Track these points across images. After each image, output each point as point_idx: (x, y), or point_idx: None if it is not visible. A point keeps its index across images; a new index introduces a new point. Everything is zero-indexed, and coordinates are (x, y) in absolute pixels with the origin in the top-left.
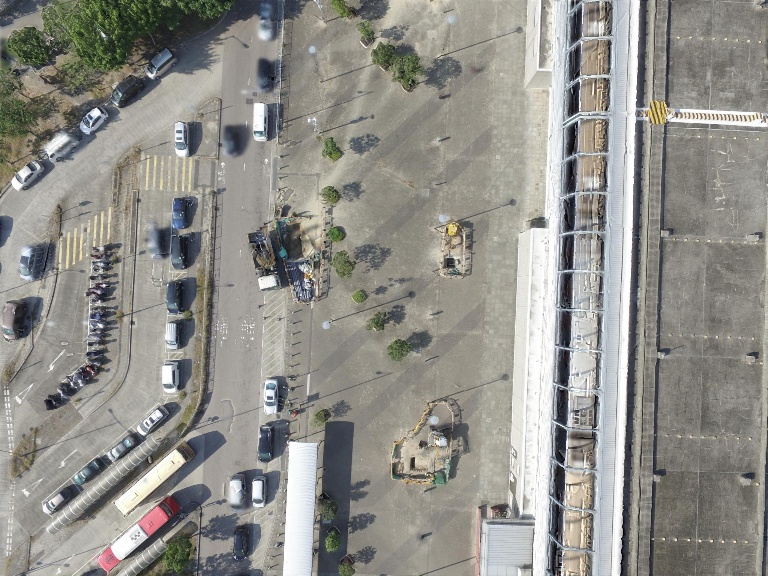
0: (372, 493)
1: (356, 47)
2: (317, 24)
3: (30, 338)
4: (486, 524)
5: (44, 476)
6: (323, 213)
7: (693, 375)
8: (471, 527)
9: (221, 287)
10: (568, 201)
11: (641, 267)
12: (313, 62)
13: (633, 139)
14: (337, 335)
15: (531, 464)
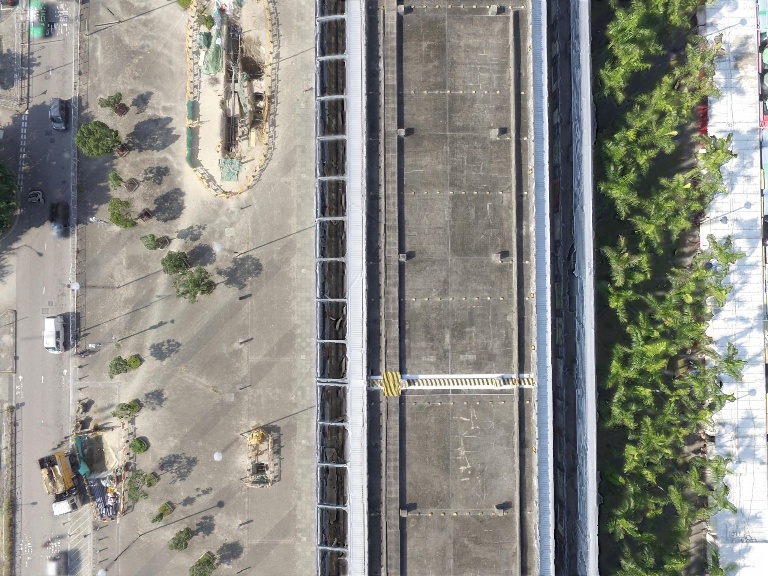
0: None
1: (152, 250)
2: (111, 228)
3: None
4: None
5: None
6: (125, 424)
7: None
8: None
9: (24, 505)
10: None
11: (383, 546)
12: (109, 267)
13: (365, 415)
14: (145, 550)
15: None
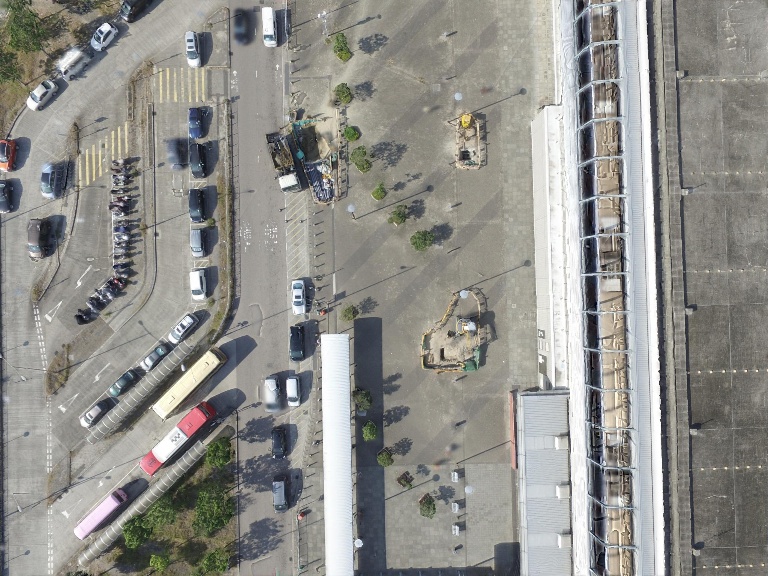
0: (404, 386)
1: None
2: None
3: (56, 256)
4: (520, 396)
5: (79, 391)
6: (337, 114)
7: (717, 211)
8: (504, 412)
9: (241, 194)
10: (580, 72)
11: (659, 109)
12: None
13: None
14: (359, 233)
15: (560, 337)
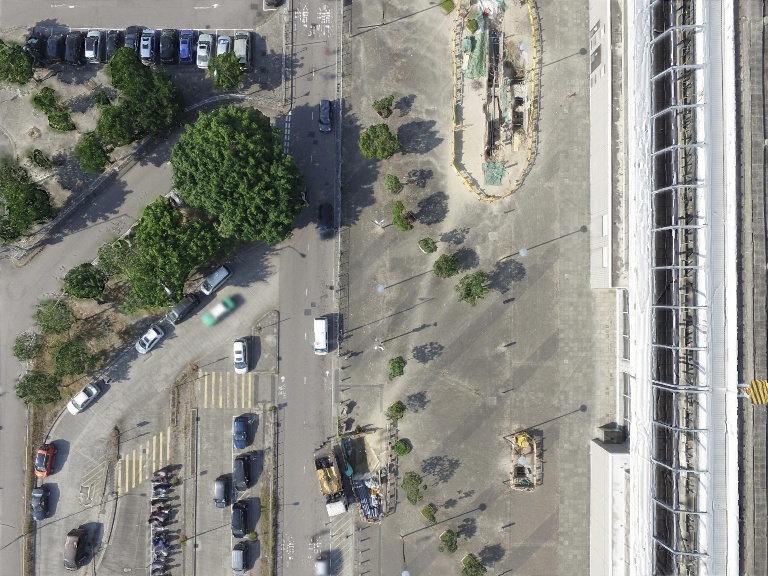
0: None
1: (416, 252)
2: (375, 230)
3: (92, 566)
4: None
5: None
6: (388, 426)
7: None
8: None
9: (286, 505)
10: None
11: (747, 553)
12: (372, 269)
13: (736, 423)
14: (407, 551)
15: None
